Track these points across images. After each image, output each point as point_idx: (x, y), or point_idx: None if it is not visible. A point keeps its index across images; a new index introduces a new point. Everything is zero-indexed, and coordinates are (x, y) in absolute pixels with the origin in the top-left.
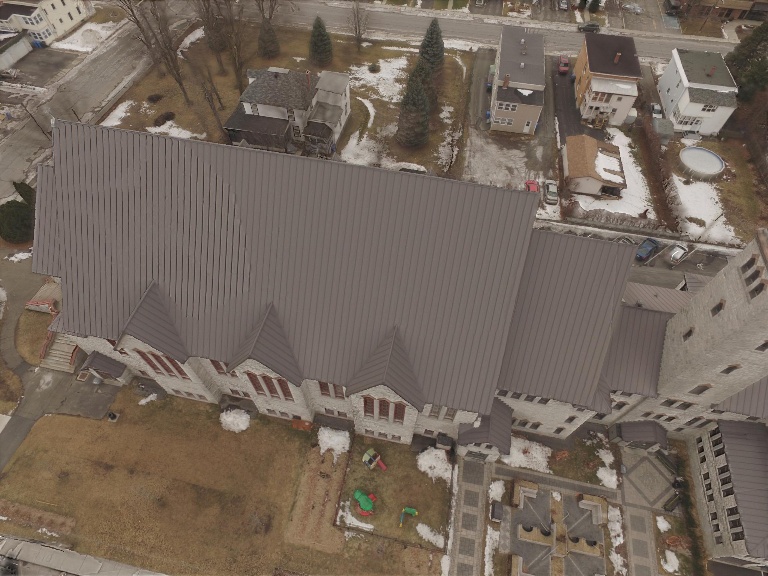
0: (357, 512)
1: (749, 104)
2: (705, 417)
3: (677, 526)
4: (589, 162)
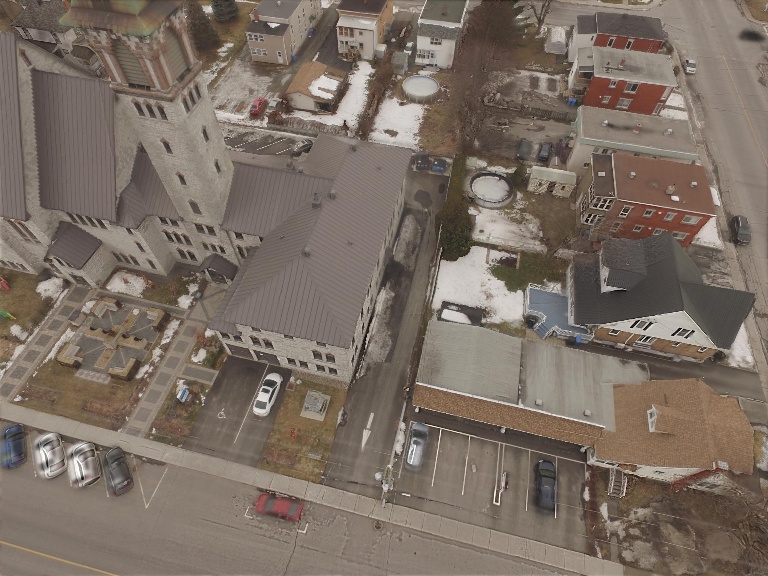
0: None
1: (475, 39)
2: (241, 245)
3: None
4: (305, 81)
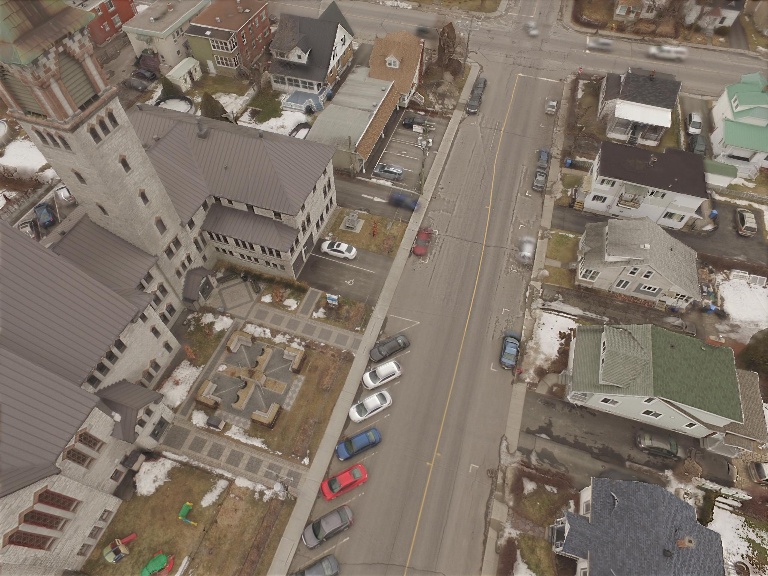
0: (166, 575)
1: None
2: (195, 236)
3: (271, 290)
4: None
